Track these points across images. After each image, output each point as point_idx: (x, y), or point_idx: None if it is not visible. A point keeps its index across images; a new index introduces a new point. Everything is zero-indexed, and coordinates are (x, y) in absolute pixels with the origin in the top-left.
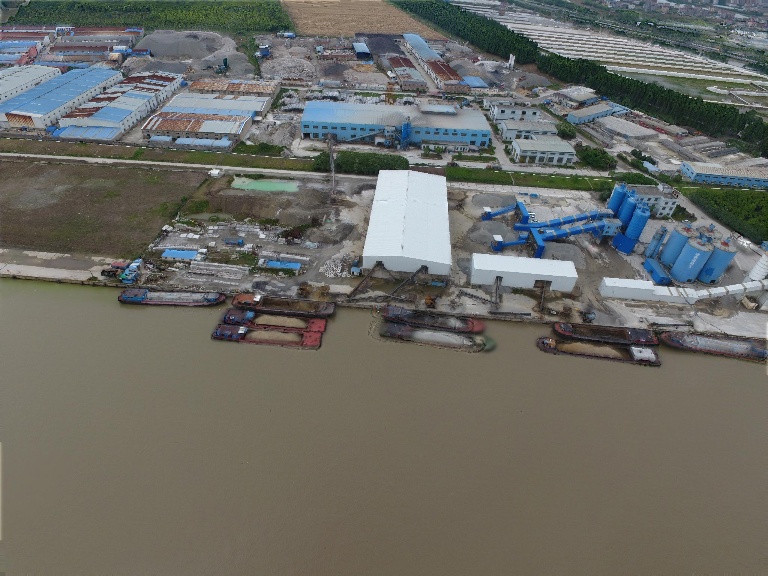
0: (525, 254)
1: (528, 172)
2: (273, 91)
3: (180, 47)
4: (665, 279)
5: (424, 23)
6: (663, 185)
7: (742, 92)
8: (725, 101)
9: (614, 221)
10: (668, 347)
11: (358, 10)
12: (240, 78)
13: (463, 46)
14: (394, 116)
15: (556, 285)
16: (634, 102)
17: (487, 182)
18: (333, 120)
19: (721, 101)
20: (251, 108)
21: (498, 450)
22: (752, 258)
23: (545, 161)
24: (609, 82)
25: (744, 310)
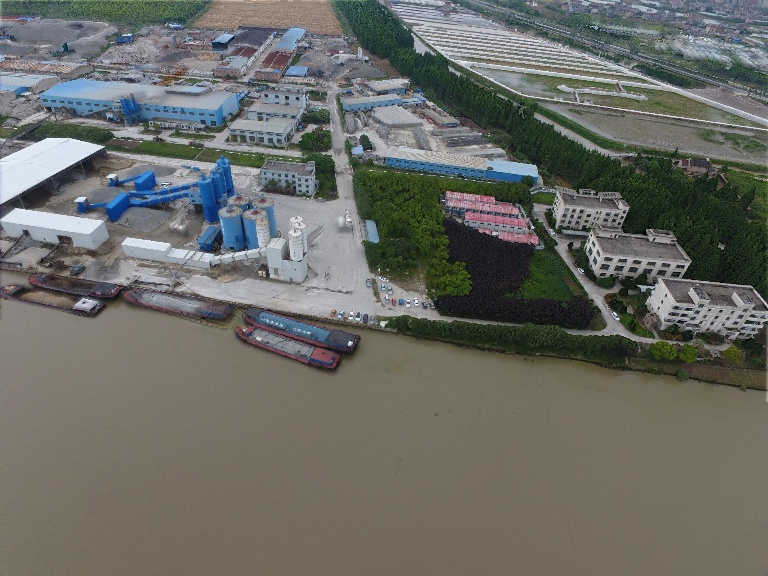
0: (107, 217)
1: (227, 150)
2: (70, 71)
3: (44, 33)
4: (204, 245)
5: (340, 20)
6: (309, 163)
7: (590, 91)
8: (555, 98)
9: (198, 190)
10: (126, 302)
11: (287, 7)
12: (70, 61)
13: (343, 41)
14: (135, 94)
15: (77, 241)
16: (442, 94)
17: (169, 156)
18: (70, 95)
19: (553, 98)
20: (24, 84)
21: None
22: (340, 235)
23: (256, 141)
24: (427, 75)
25: (254, 277)
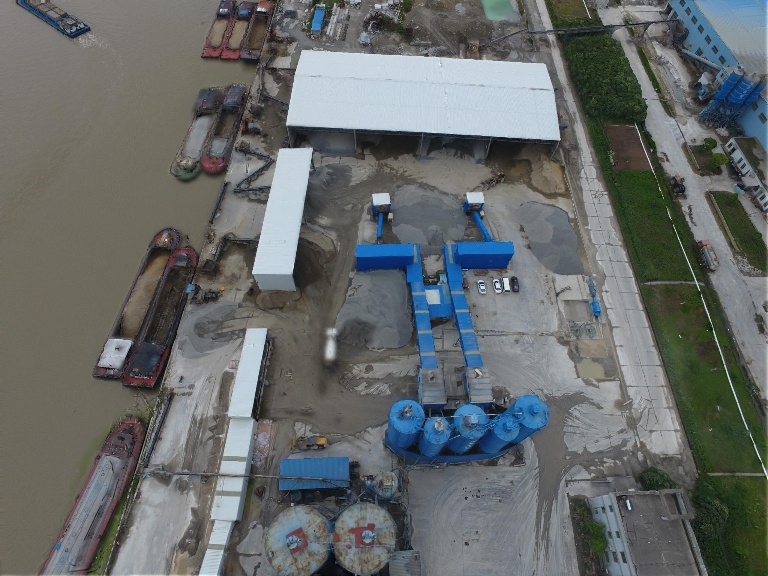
0: None
1: (729, 327)
2: None
3: None
4: None
5: None
6: None
7: None
8: None
9: (433, 389)
10: None
11: None
12: None
13: None
14: None
15: None
16: None
17: (625, 234)
18: (709, 8)
19: None
20: None
21: (40, 168)
22: None
23: None
24: None
25: None
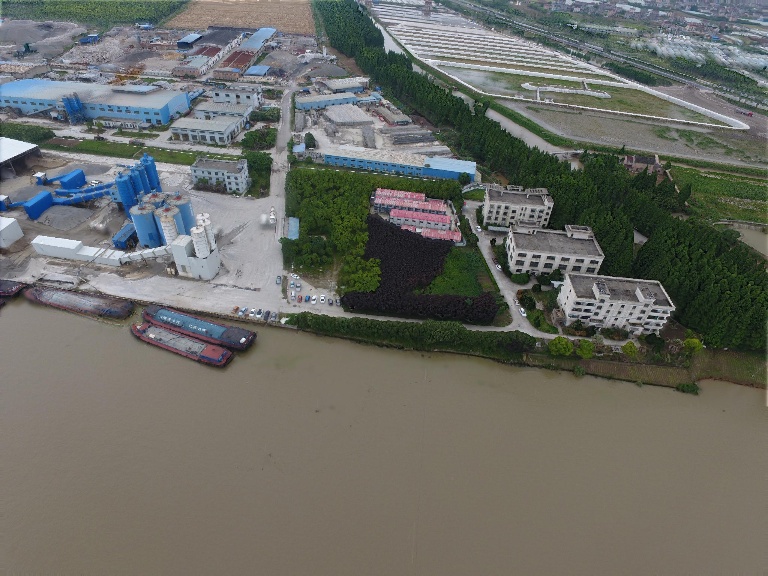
0: None
1: (168, 148)
2: (25, 71)
3: (8, 34)
4: (118, 242)
5: (316, 20)
6: (240, 161)
7: (553, 89)
8: (516, 96)
9: None
10: (27, 300)
11: (264, 8)
12: (30, 61)
13: (313, 40)
14: (81, 93)
15: None
16: (400, 93)
17: (107, 154)
18: (15, 95)
19: (514, 96)
20: None
21: None
22: (262, 232)
23: (199, 139)
24: (386, 73)
25: (163, 275)
